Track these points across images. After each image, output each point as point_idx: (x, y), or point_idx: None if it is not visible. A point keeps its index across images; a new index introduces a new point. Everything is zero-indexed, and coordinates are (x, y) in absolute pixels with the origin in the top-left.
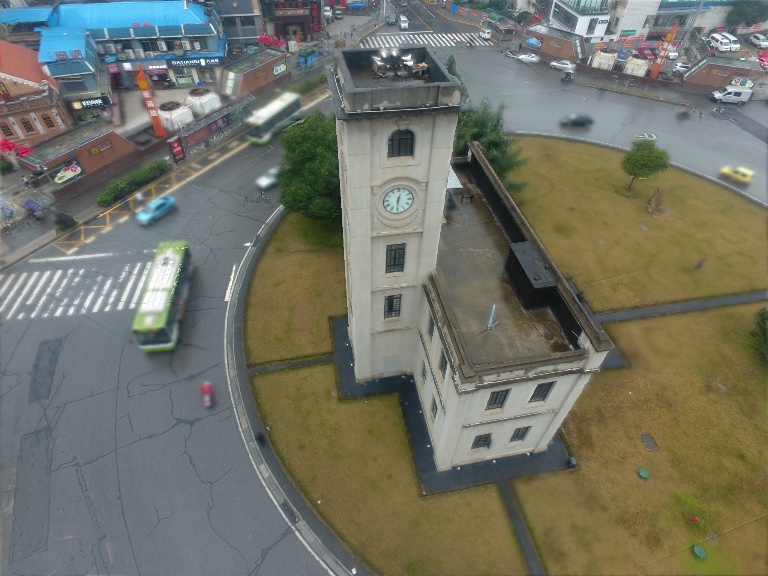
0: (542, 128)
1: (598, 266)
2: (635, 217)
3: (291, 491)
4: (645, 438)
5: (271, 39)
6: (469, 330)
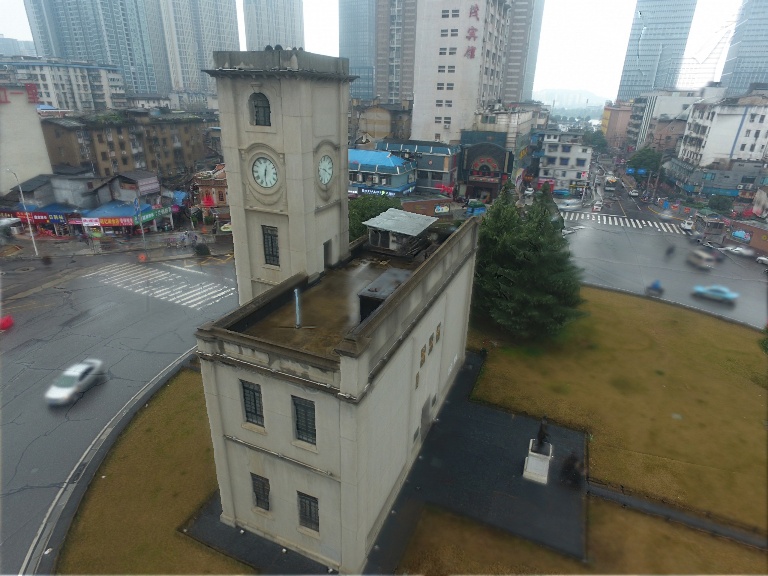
0: (692, 302)
1: (645, 436)
2: (763, 412)
3: (100, 456)
4: None
5: (445, 187)
6: (278, 321)
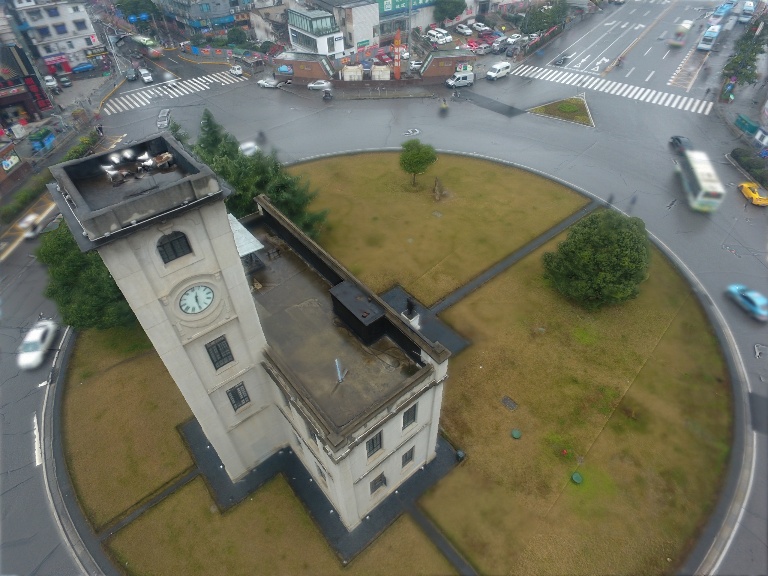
0: (322, 149)
1: (415, 263)
2: (428, 208)
3: None
4: (506, 402)
5: None
6: (322, 392)
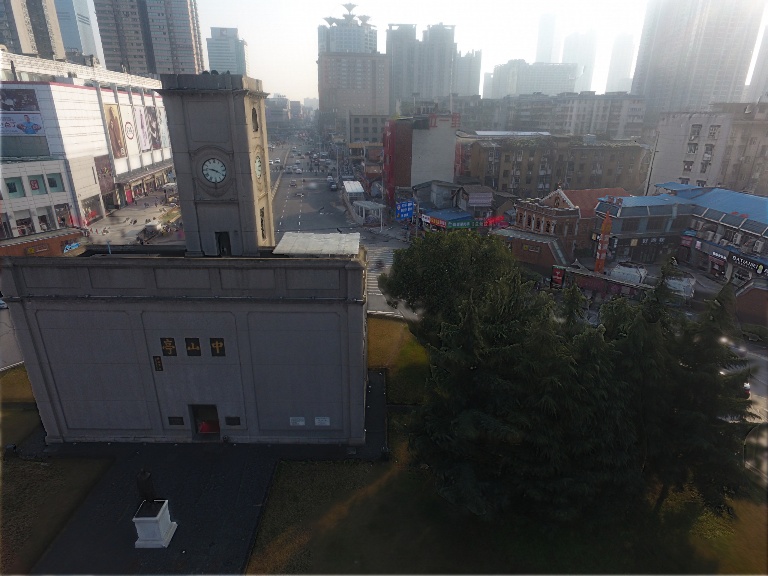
0: None
1: None
2: None
3: None
4: None
5: None
6: None
